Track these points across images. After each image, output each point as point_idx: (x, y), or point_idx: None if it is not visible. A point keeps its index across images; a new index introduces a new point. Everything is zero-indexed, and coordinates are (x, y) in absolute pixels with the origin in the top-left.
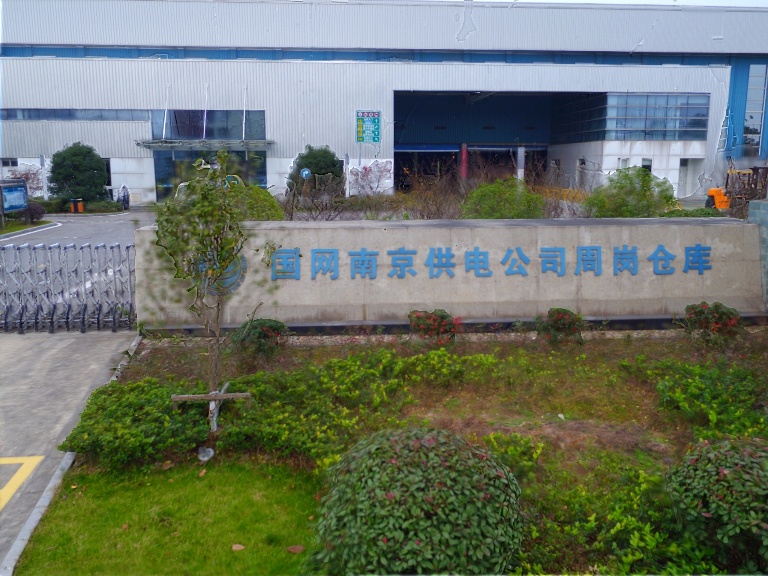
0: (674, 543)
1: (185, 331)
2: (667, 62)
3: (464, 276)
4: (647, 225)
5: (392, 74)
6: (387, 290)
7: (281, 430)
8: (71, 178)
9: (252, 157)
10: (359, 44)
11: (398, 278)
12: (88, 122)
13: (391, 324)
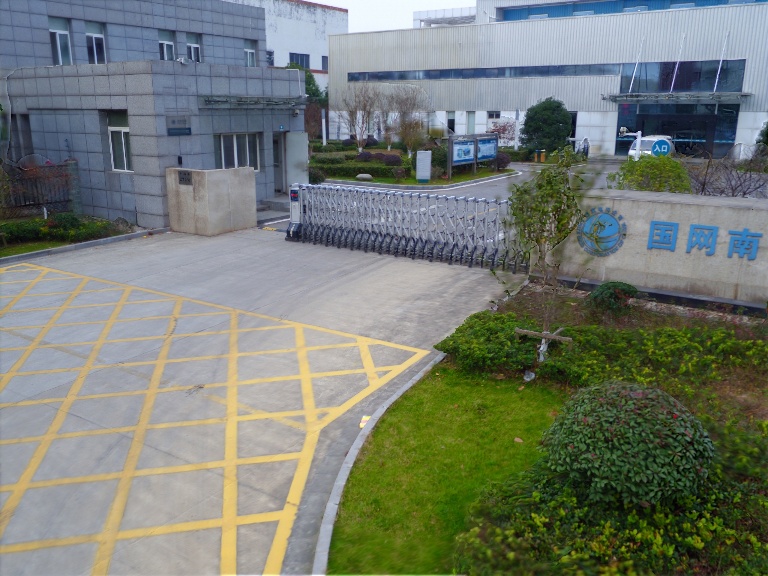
0: None
1: (564, 282)
2: None
3: None
4: None
5: None
6: (765, 273)
7: (585, 372)
8: (539, 130)
9: (723, 111)
10: None
11: None
12: (563, 77)
13: (761, 308)
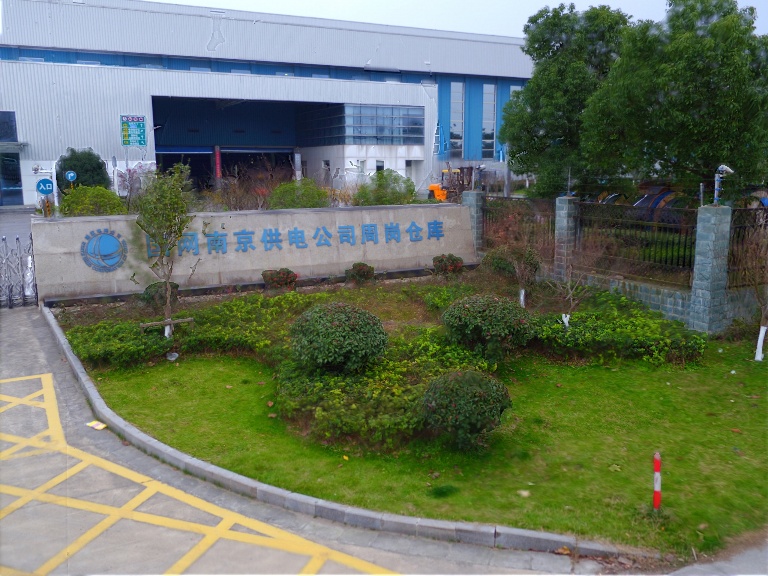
0: (448, 346)
1: (84, 300)
2: (390, 80)
3: (289, 248)
4: (404, 209)
5: (149, 80)
6: (235, 261)
7: (222, 335)
8: None
9: (3, 159)
10: (105, 47)
11: (243, 252)
12: None
13: (242, 284)
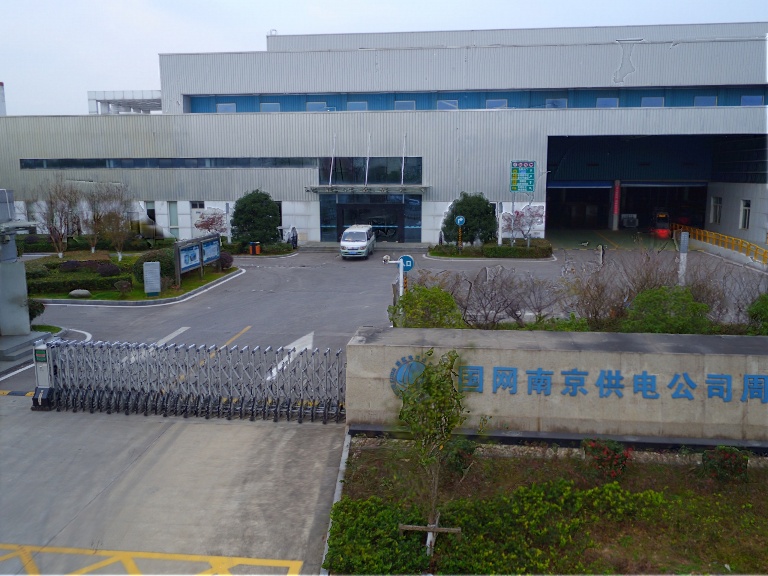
0: None
1: (386, 433)
2: None
3: (632, 397)
4: None
5: (547, 120)
6: (560, 406)
7: (488, 568)
8: (250, 222)
9: (408, 200)
10: (513, 85)
11: (570, 396)
12: (264, 169)
13: (563, 438)
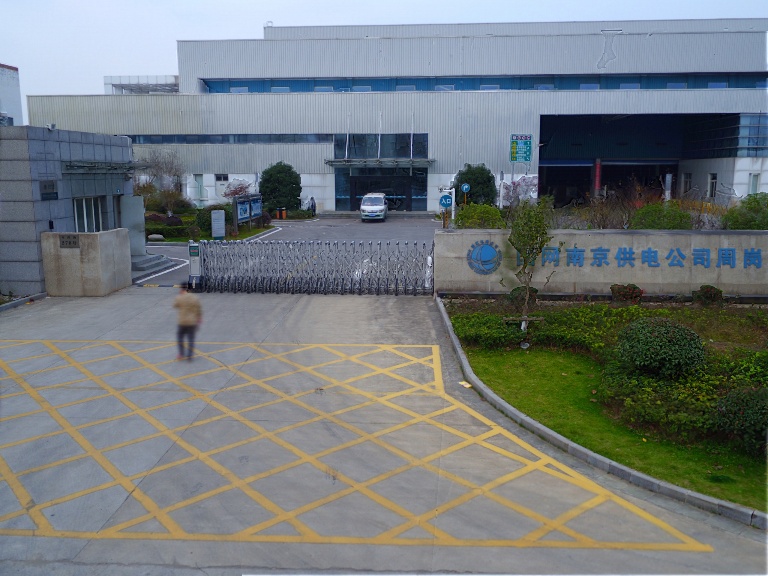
0: None
1: (466, 295)
2: None
3: (641, 266)
4: None
5: (539, 101)
6: (590, 274)
7: (565, 334)
8: (276, 191)
9: (415, 173)
10: (505, 71)
11: (597, 266)
12: (284, 145)
13: (593, 295)
